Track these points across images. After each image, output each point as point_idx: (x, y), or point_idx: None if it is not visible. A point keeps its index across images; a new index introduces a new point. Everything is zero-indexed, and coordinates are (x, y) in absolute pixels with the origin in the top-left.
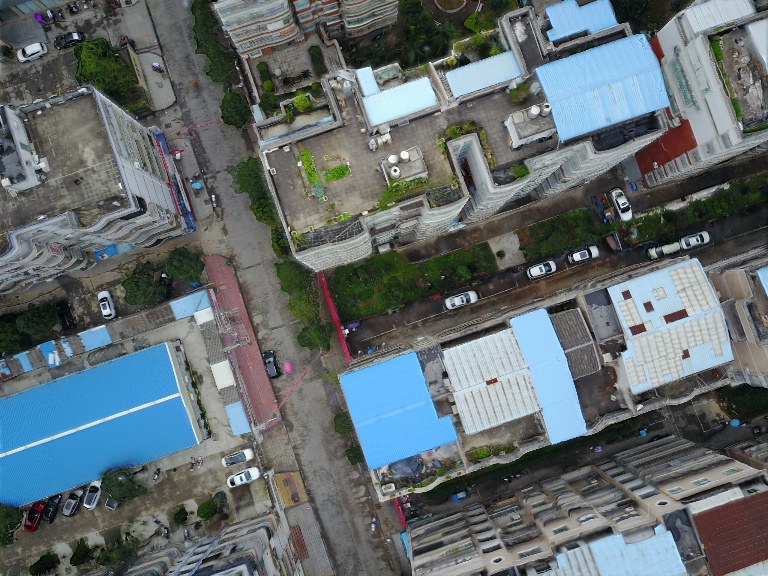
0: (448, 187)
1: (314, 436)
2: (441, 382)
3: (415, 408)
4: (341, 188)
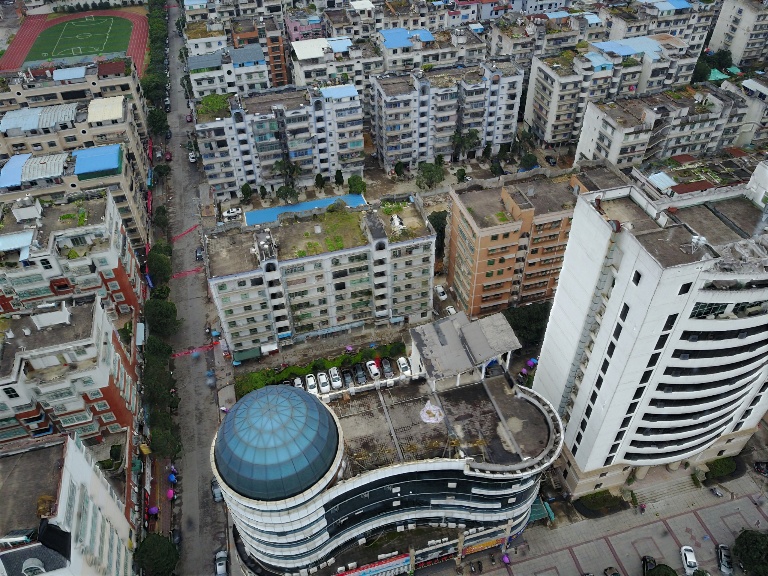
0: None
1: None
2: (69, 167)
3: None
4: (69, 212)
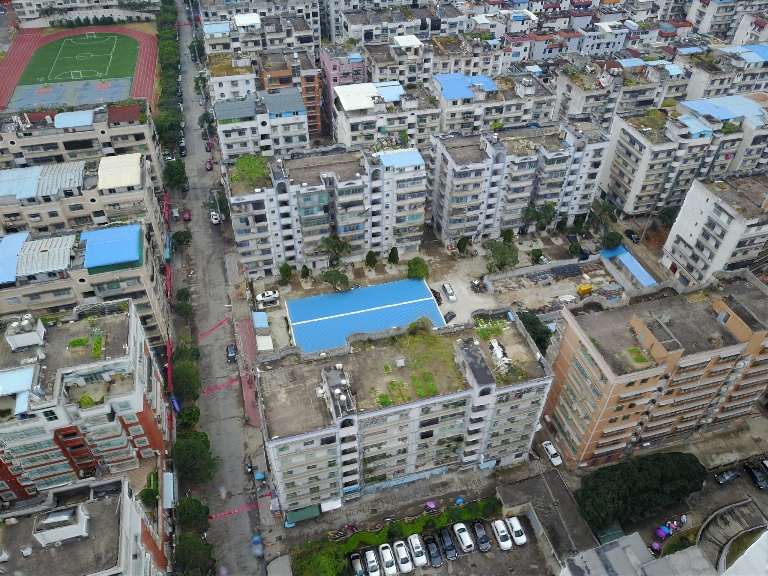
0: (3, 328)
1: (215, 316)
2: (77, 256)
3: (98, 243)
4: (81, 335)
